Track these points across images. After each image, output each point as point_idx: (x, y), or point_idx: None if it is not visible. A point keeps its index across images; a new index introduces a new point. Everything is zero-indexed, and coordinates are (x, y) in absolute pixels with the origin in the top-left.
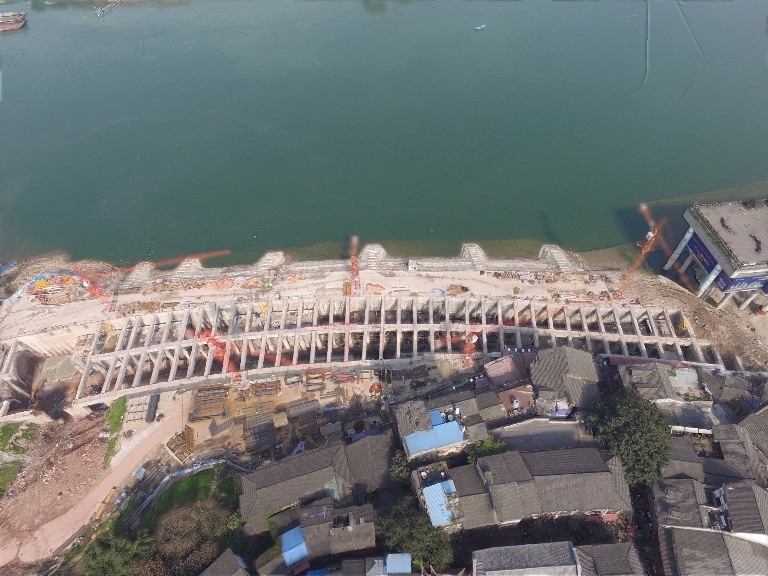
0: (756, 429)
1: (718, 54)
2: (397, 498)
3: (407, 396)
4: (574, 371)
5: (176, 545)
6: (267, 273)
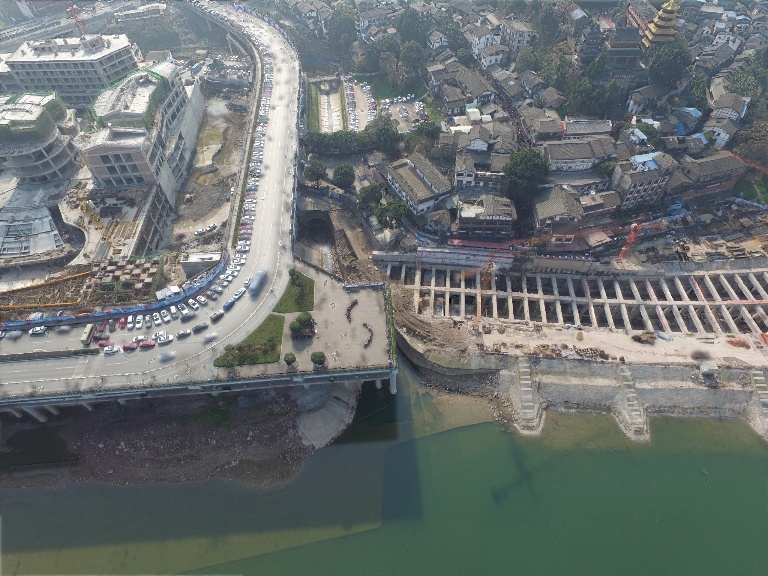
0: (444, 181)
1: None
2: None
3: (658, 241)
4: (558, 200)
5: (760, 133)
6: None
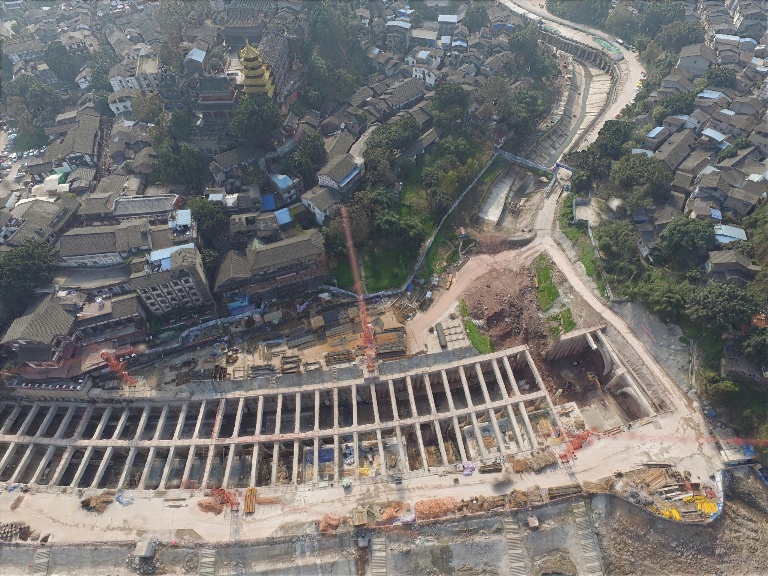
0: None
1: None
2: (220, 254)
3: (203, 351)
4: (30, 317)
5: (352, 208)
6: (364, 518)
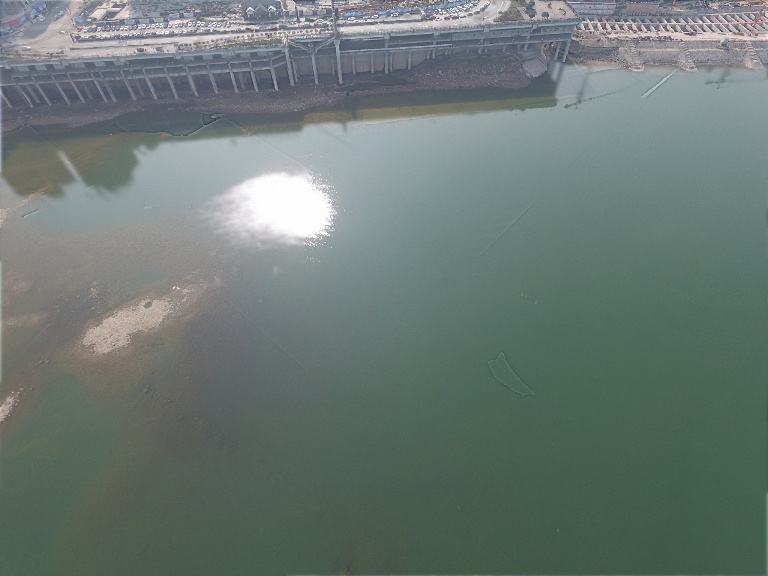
0: None
1: (383, 382)
2: None
3: (692, 1)
4: None
5: None
6: None
